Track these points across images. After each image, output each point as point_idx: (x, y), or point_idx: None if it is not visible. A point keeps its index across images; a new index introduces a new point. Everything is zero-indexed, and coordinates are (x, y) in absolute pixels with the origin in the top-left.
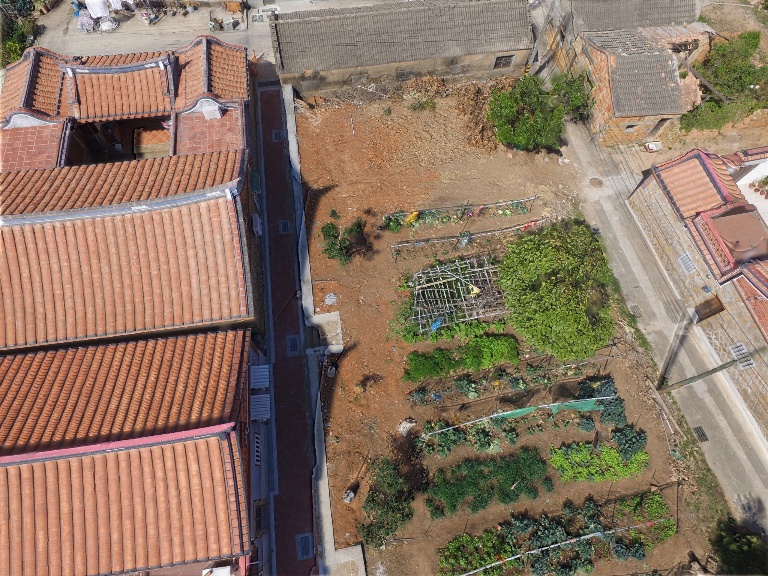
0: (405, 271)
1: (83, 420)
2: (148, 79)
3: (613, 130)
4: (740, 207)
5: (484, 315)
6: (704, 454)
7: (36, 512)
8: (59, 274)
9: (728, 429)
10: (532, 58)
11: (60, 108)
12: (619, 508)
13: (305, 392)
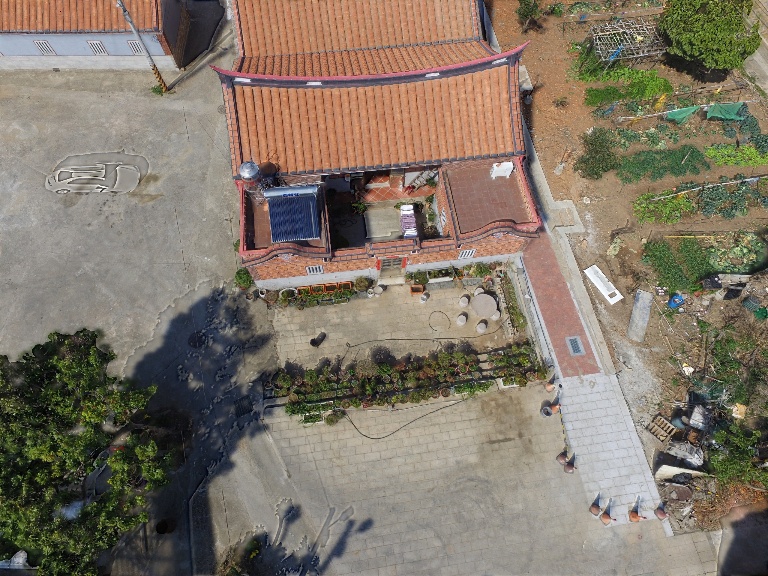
0: (571, 41)
1: None
2: None
3: None
4: None
5: (648, 54)
6: None
7: (378, 120)
8: (340, 3)
9: None
10: None
11: None
12: (761, 181)
13: None
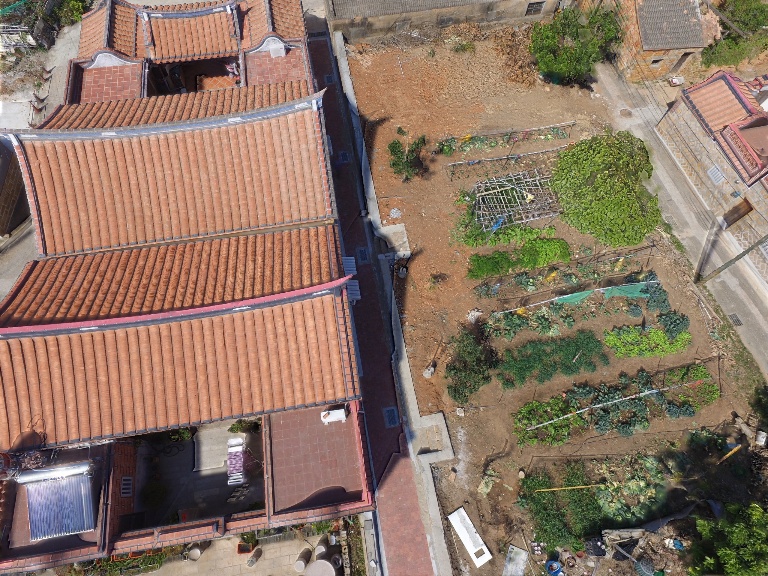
0: (460, 188)
1: (206, 292)
2: (216, 23)
3: (640, 65)
4: (764, 119)
5: (539, 217)
6: (739, 336)
7: (175, 365)
8: (163, 181)
9: (759, 315)
10: (563, 2)
11: (137, 50)
12: (668, 378)
13: (378, 293)
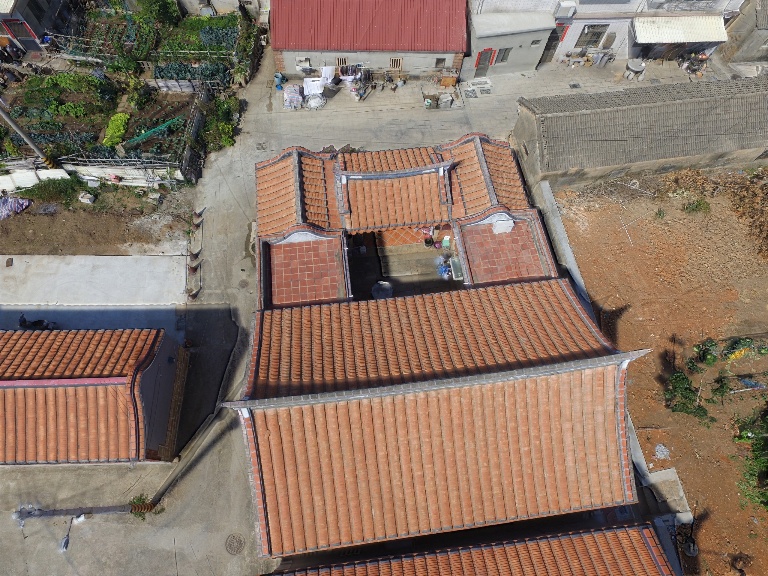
0: (735, 416)
1: None
2: (423, 185)
3: None
4: None
5: None
6: None
7: None
8: (419, 452)
9: None
10: None
11: (329, 218)
12: None
13: None
